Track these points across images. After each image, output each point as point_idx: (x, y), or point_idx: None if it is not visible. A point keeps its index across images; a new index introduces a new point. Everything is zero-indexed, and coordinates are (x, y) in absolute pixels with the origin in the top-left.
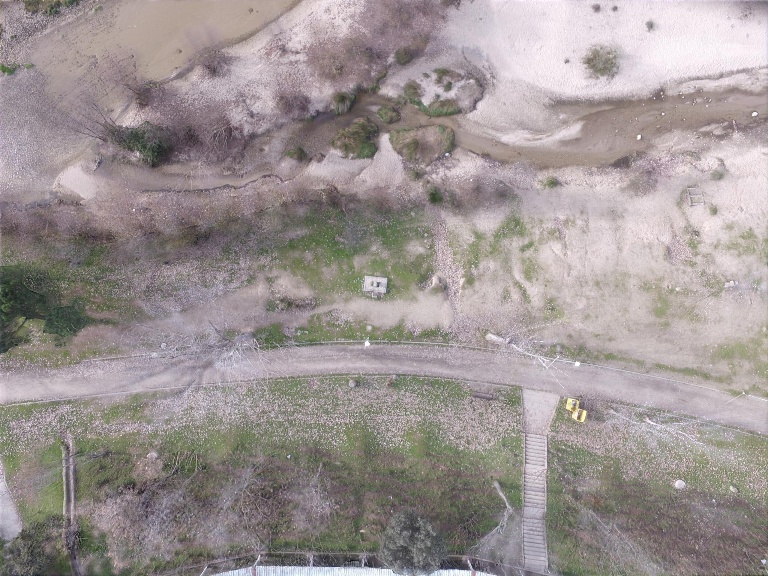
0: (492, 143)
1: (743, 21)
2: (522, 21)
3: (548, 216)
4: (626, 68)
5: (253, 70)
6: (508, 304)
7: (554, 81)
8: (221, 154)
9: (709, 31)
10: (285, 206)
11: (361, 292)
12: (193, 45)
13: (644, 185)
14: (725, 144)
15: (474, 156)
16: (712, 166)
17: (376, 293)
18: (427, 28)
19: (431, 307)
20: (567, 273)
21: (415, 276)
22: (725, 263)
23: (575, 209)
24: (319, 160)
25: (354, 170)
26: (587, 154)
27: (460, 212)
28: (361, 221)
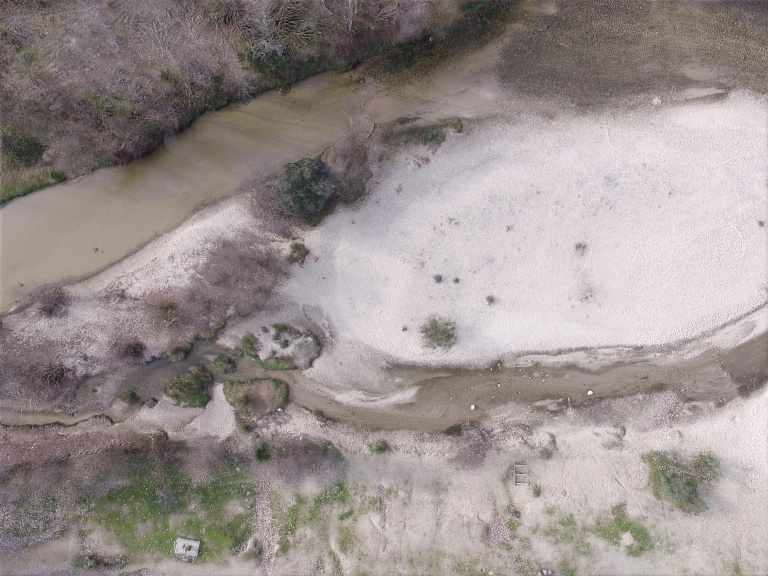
0: (326, 401)
1: (583, 303)
2: (364, 284)
3: (372, 484)
4: (464, 339)
5: (91, 312)
6: (320, 575)
7: (392, 346)
8: (53, 392)
9: (549, 309)
10: (111, 451)
11: (173, 553)
12: (35, 280)
13: (472, 458)
14: (558, 420)
15: (307, 413)
16: (543, 442)
17: (187, 556)
18: (269, 283)
19: (242, 573)
20: (383, 547)
21: (229, 540)
22: (541, 550)
23: (400, 478)
24: (150, 406)
25: (185, 418)
26: (420, 419)
27: (285, 472)
28: (184, 474)
